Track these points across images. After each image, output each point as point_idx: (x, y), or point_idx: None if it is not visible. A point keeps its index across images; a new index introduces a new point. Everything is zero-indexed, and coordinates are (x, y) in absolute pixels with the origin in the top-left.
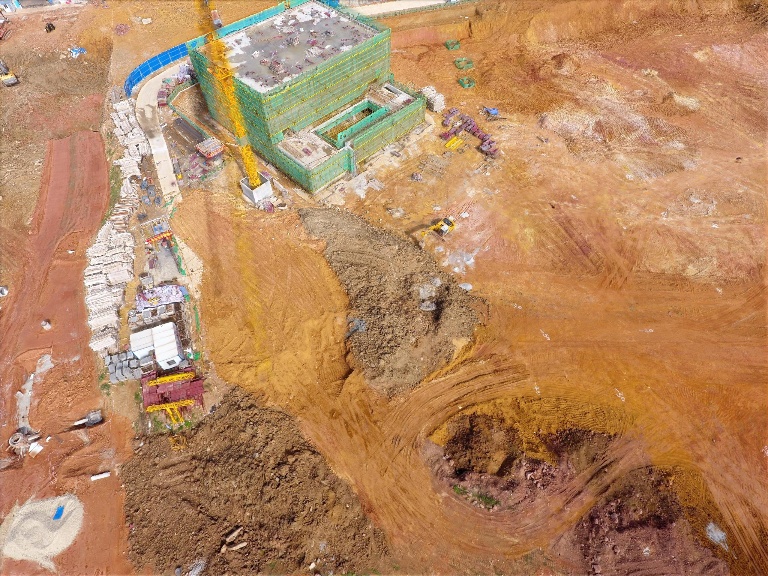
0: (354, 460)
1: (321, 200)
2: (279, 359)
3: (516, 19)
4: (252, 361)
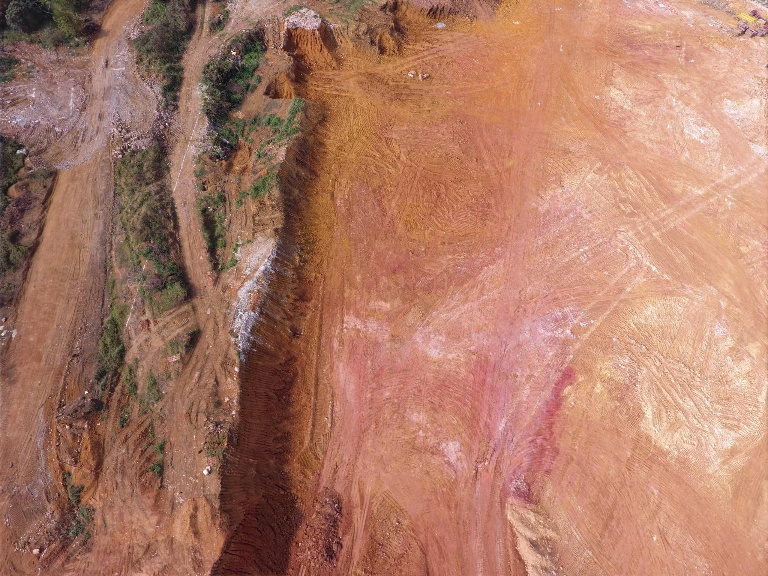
0: None
1: None
2: None
3: None
4: None
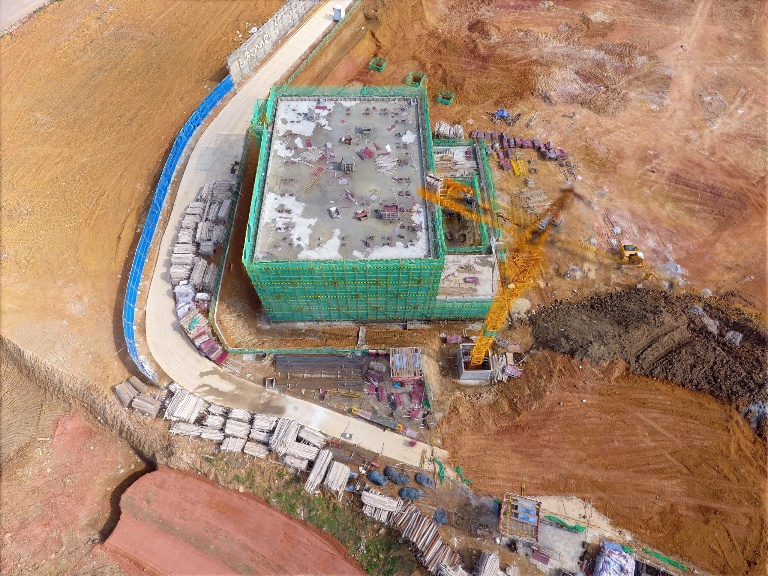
0: None
1: (507, 317)
2: (765, 510)
3: (405, 7)
4: (760, 539)
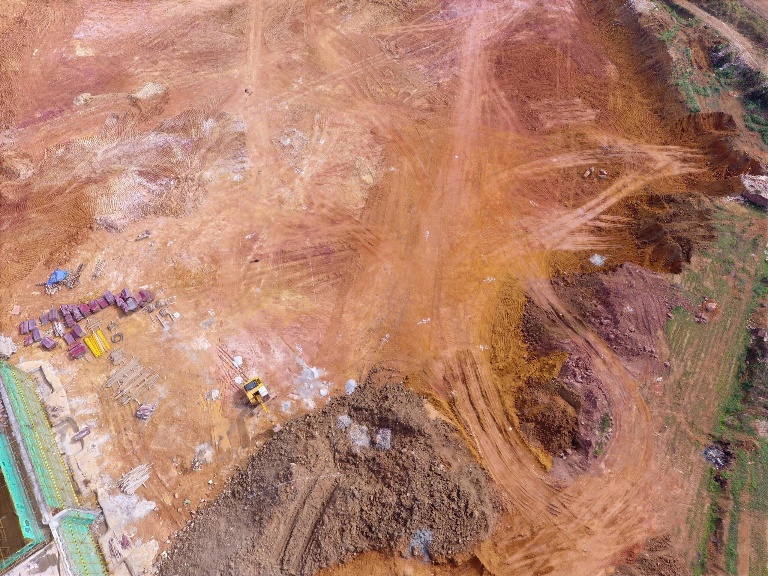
0: (579, 567)
1: None
2: None
3: None
4: None
